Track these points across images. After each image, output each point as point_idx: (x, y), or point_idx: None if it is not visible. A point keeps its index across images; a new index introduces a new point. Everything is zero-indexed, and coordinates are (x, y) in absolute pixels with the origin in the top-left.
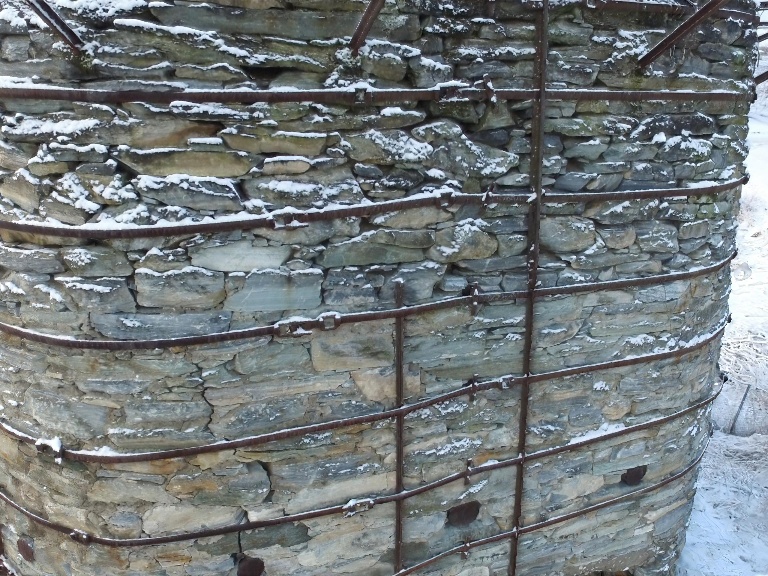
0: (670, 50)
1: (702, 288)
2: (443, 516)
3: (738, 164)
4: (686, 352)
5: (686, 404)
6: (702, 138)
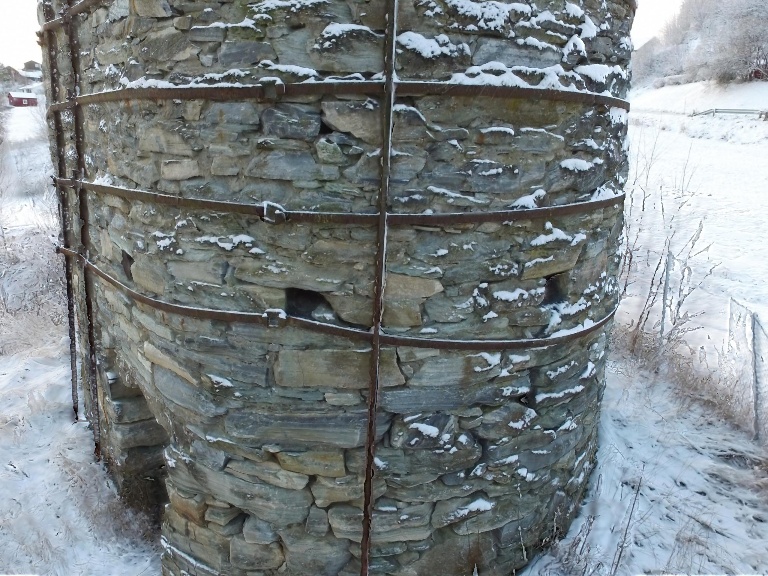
0: None
1: (143, 1)
2: (80, 221)
3: None
4: (129, 96)
5: (148, 186)
6: None
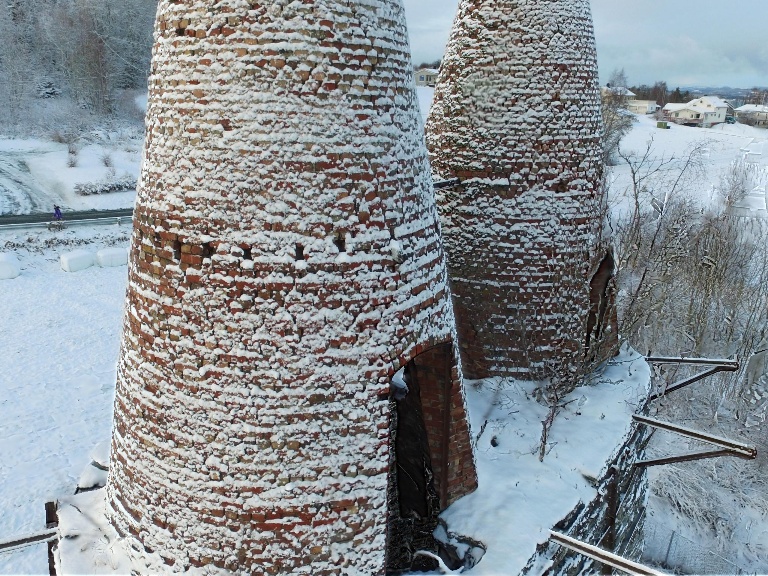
0: None
1: None
2: None
3: None
4: None
5: None
6: None
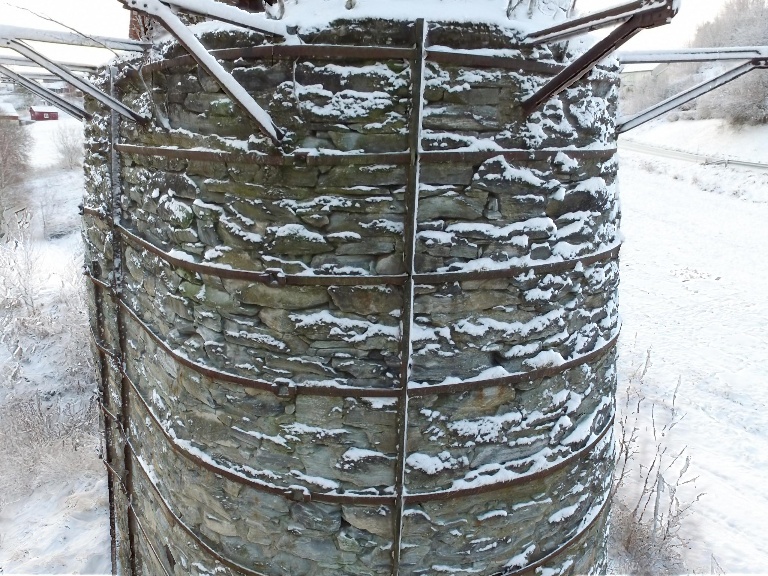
0: (165, 106)
1: None
2: None
3: (253, 251)
4: None
5: (192, 523)
6: (190, 202)
